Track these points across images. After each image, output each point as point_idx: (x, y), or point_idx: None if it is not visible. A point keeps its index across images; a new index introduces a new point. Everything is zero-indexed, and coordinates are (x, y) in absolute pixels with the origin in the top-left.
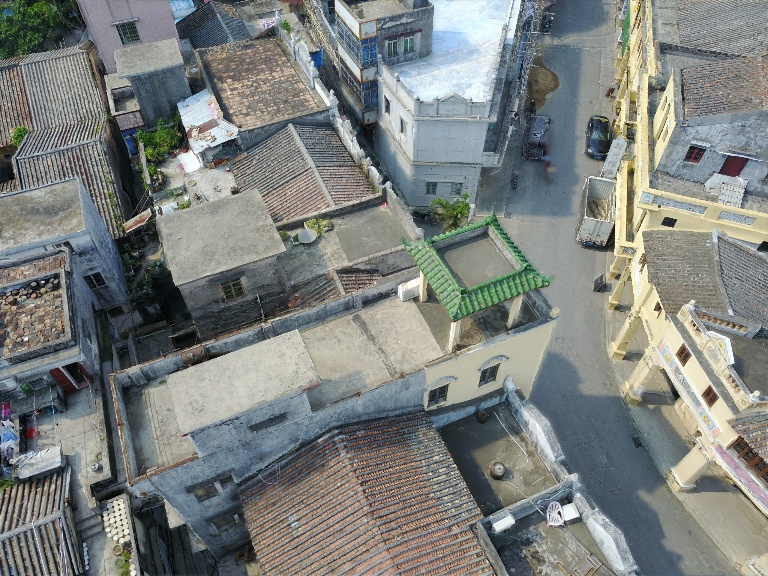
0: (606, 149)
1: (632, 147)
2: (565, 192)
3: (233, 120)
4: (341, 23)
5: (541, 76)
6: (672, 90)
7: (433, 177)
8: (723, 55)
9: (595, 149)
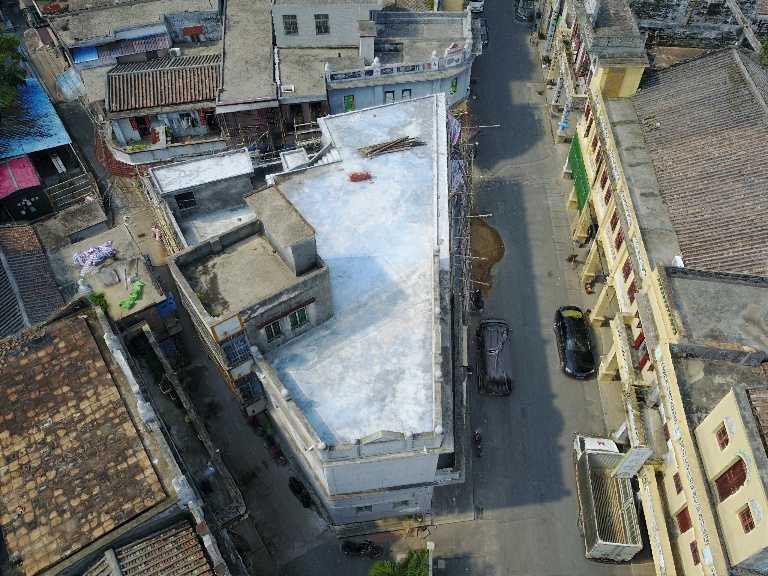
0: (589, 364)
1: (646, 417)
2: (549, 450)
3: (7, 546)
4: (185, 296)
5: (480, 243)
6: (741, 434)
7: (364, 501)
8: (756, 278)
9: (574, 366)
